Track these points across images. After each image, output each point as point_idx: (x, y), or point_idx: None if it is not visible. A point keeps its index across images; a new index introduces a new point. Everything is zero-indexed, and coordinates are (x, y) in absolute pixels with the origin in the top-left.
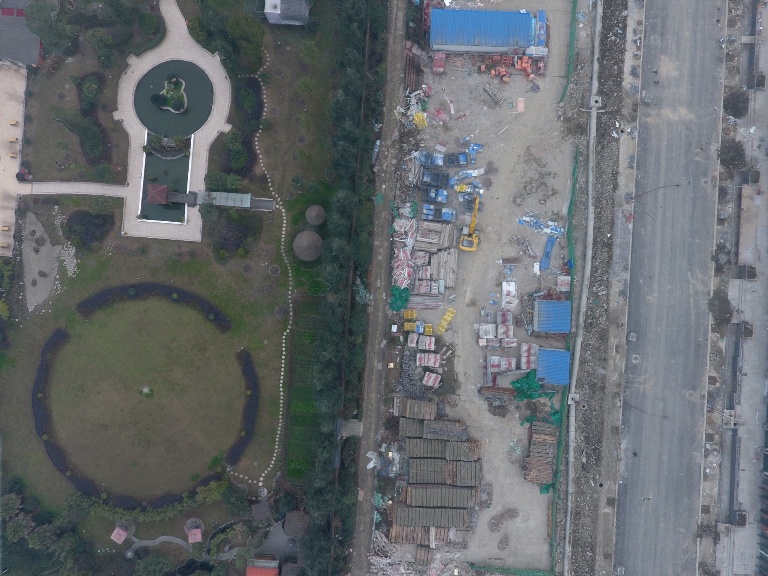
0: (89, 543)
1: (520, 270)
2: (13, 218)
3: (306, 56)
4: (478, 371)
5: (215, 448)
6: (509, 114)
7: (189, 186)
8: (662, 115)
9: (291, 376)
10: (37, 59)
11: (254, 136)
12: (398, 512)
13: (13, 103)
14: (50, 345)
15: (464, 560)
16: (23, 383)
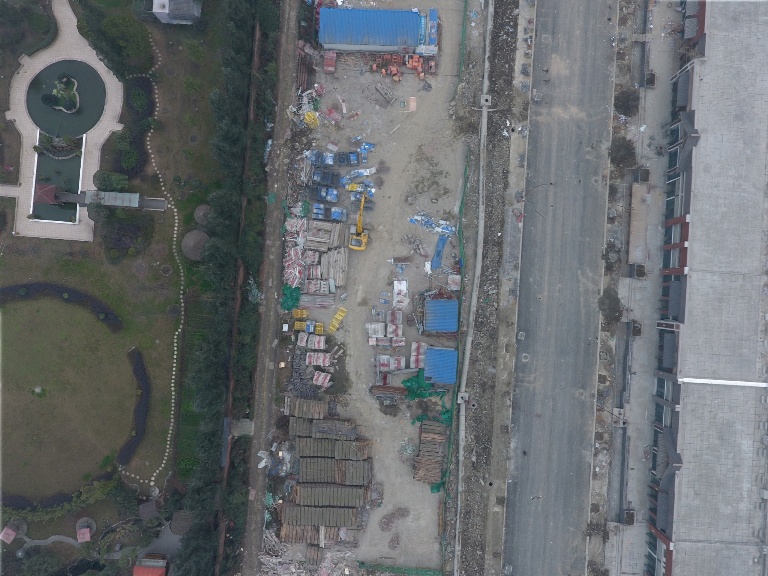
0: None
1: (412, 269)
2: None
3: (191, 55)
4: (369, 370)
5: (107, 448)
6: (401, 113)
7: (81, 186)
8: (553, 114)
9: (182, 376)
10: None
11: (146, 136)
12: (286, 511)
13: None
14: None
15: (355, 559)
16: None
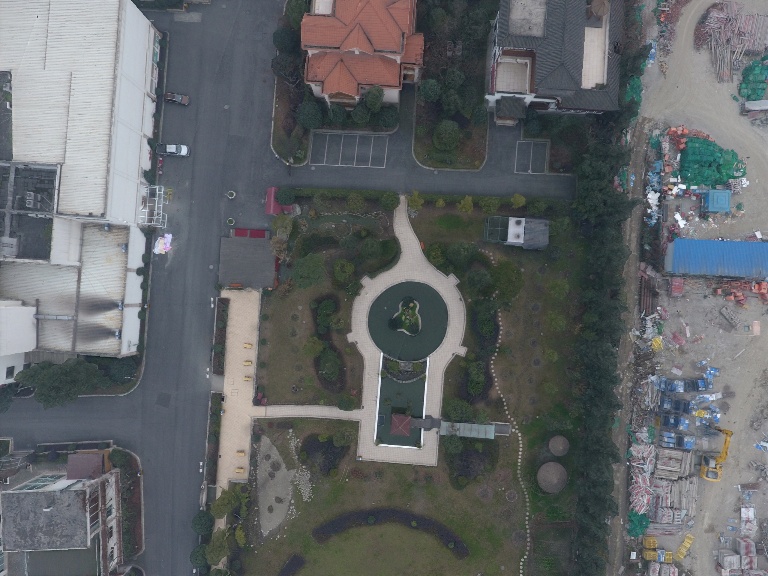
0: None
1: (758, 496)
2: (247, 441)
3: (557, 293)
4: None
5: None
6: (745, 337)
7: (425, 410)
8: None
9: None
10: (271, 281)
11: (490, 359)
12: None
13: (246, 324)
14: (287, 573)
15: None
16: None
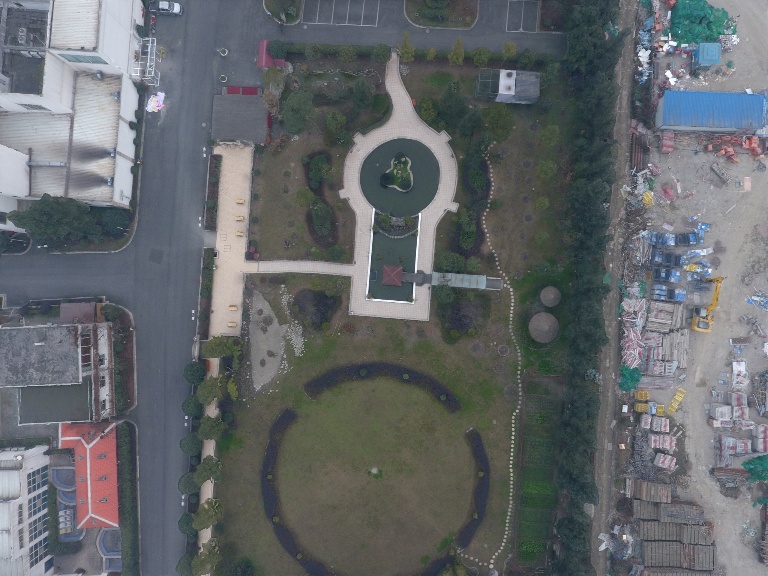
0: None
1: (750, 350)
2: (239, 297)
3: (548, 140)
4: (709, 452)
5: (445, 530)
6: (736, 193)
7: (417, 265)
8: None
9: (523, 457)
10: (263, 137)
11: (481, 215)
12: None
13: (239, 181)
14: (279, 426)
15: None
16: (250, 464)
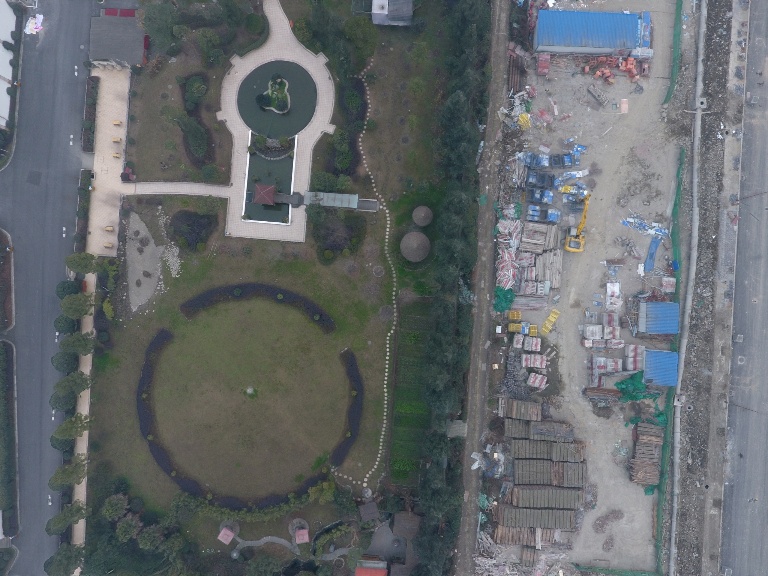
0: (194, 543)
1: (624, 271)
2: (116, 218)
3: (417, 57)
4: (582, 372)
5: (319, 449)
6: (613, 115)
7: (293, 187)
8: (767, 117)
9: (396, 377)
10: (140, 59)
11: (358, 137)
12: (505, 513)
13: (116, 103)
14: (155, 345)
15: (569, 561)
16: (127, 383)
